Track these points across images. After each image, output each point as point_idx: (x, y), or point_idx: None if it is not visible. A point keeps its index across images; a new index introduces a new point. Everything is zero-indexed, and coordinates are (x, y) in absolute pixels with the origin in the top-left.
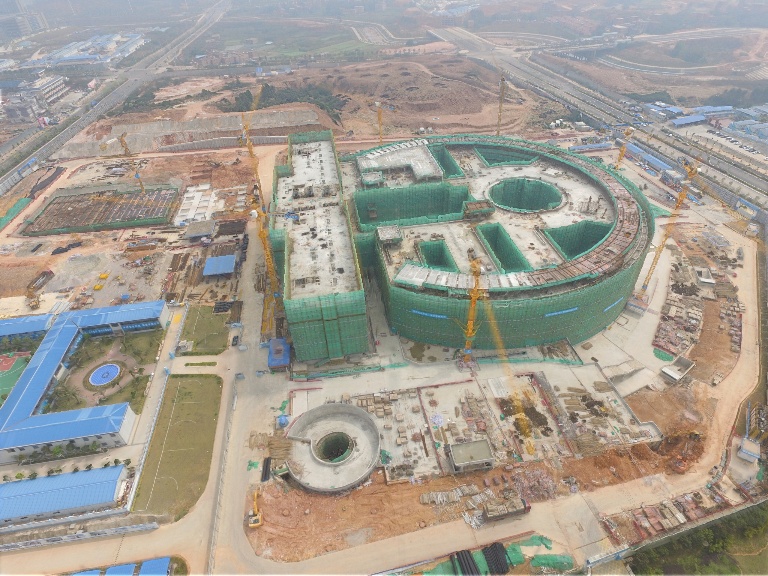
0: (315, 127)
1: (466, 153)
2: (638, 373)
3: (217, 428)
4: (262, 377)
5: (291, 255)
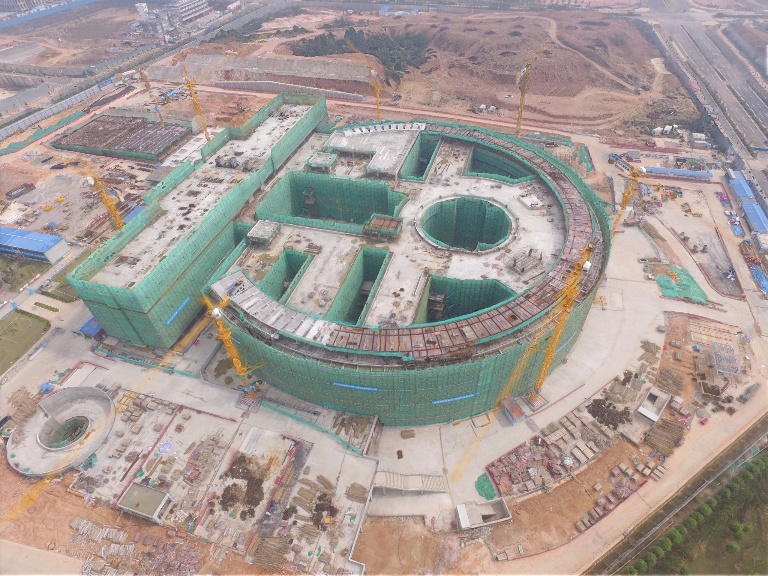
0: (362, 85)
1: (460, 151)
2: (432, 495)
3: (6, 371)
4: (76, 338)
5: (147, 228)
